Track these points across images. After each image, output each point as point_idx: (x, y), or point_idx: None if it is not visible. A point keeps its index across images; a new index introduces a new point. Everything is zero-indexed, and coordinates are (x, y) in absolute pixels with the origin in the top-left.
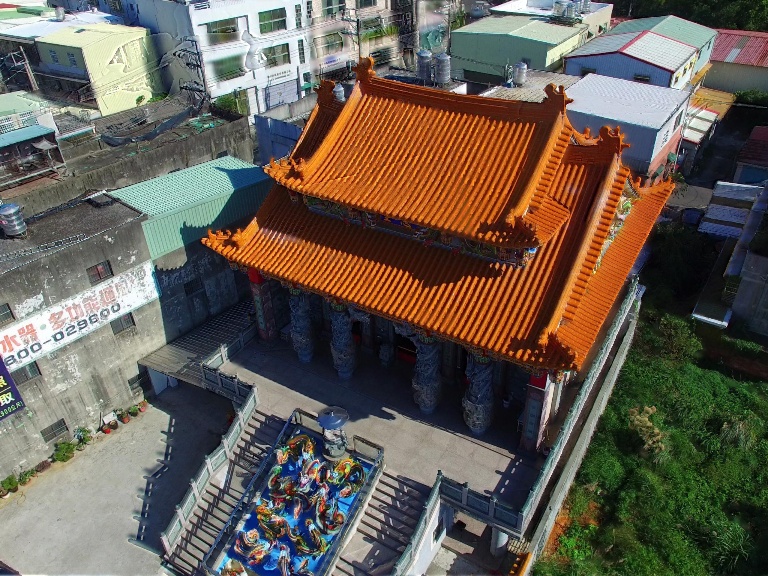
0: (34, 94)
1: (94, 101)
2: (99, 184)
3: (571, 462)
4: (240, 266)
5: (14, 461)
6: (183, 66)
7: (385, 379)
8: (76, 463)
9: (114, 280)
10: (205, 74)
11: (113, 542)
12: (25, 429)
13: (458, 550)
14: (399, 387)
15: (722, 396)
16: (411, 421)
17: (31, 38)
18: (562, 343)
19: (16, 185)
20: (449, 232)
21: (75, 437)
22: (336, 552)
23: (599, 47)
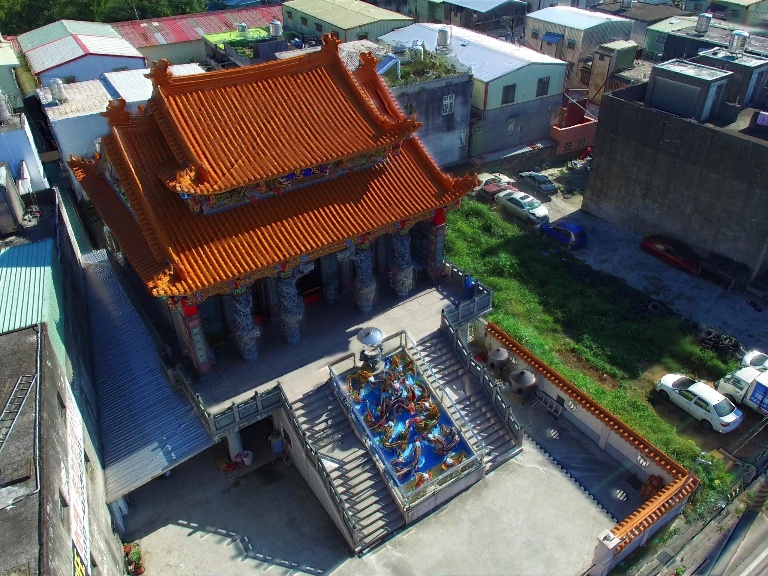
0: None
1: None
2: None
3: None
4: (190, 299)
5: None
6: None
7: (318, 320)
8: None
9: None
10: None
11: None
12: None
13: None
14: (333, 316)
15: None
16: (371, 321)
17: None
18: None
19: None
20: None
21: None
22: (444, 407)
23: (55, 57)
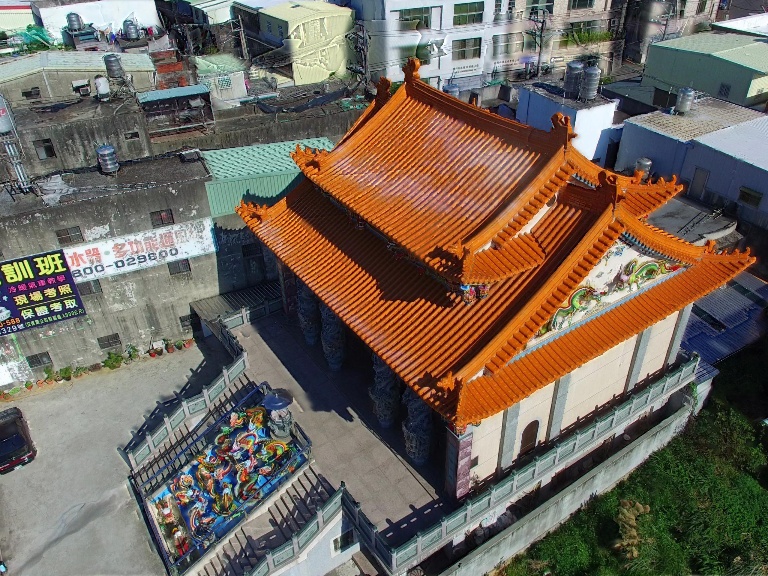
0: (212, 58)
1: (291, 71)
2: (235, 144)
3: (512, 528)
4: None
5: (73, 356)
6: (352, 48)
7: (367, 381)
8: (119, 373)
9: (174, 227)
10: (367, 58)
11: (107, 445)
12: (84, 333)
13: (363, 568)
14: None
15: (767, 527)
16: (365, 428)
17: (256, 9)
18: (460, 392)
19: (174, 133)
20: (406, 249)
21: (126, 352)
22: (240, 521)
23: None
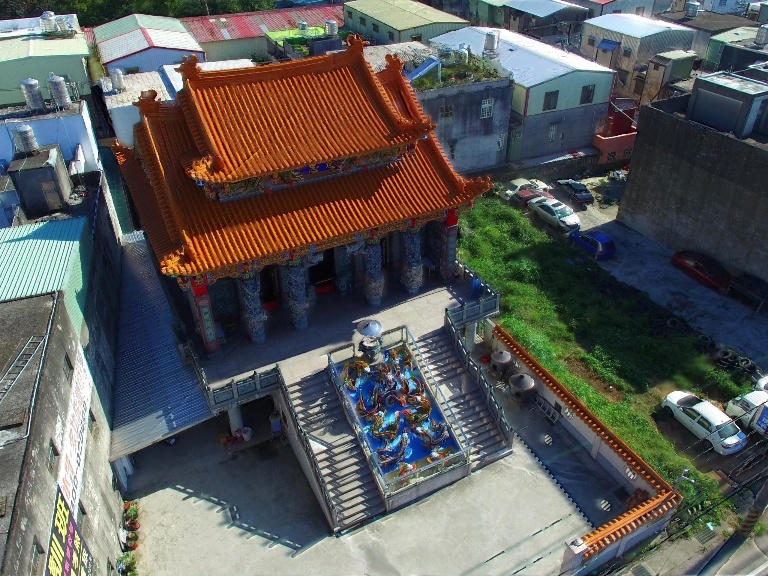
0: None
1: None
2: None
3: None
4: (199, 279)
5: None
6: None
7: (328, 310)
8: None
9: (75, 375)
10: None
11: (284, 571)
12: None
13: None
14: (342, 307)
15: None
16: (378, 315)
17: None
18: None
19: None
20: (371, 151)
21: None
22: (437, 403)
23: (123, 48)
